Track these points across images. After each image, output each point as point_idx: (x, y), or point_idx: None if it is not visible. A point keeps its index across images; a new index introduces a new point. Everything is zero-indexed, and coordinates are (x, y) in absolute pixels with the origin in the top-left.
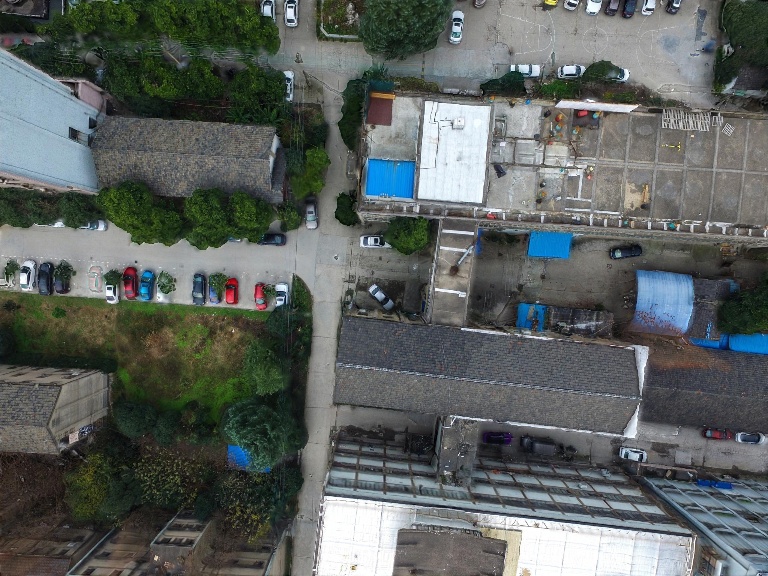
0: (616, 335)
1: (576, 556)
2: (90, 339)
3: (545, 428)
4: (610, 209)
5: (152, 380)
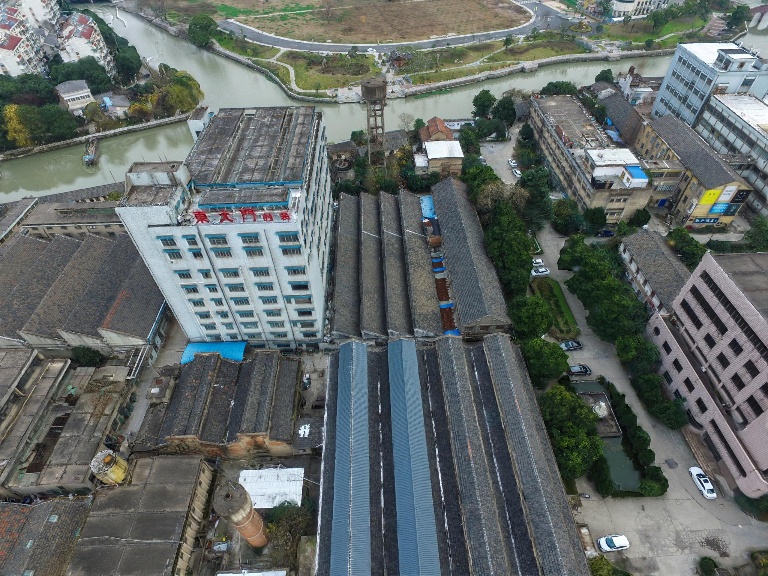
0: (630, 147)
1: None
2: None
3: None
4: (597, 132)
5: None
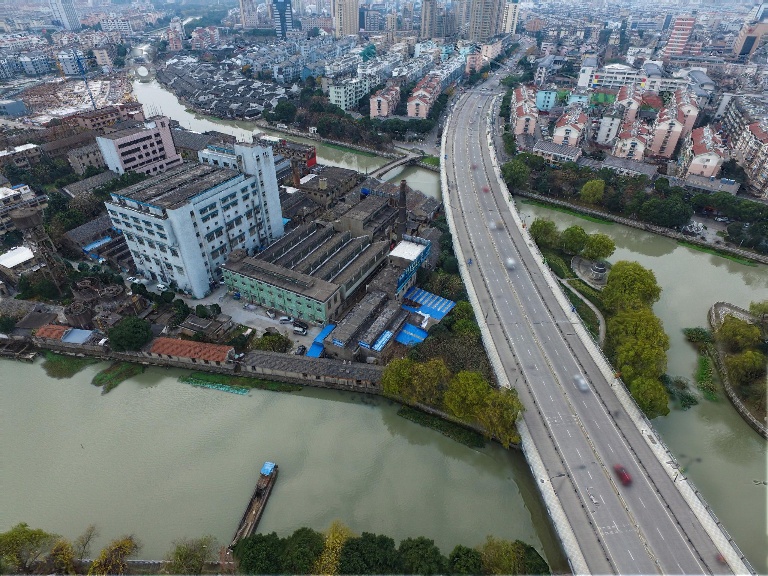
0: None
1: None
2: None
3: None
4: None
5: None
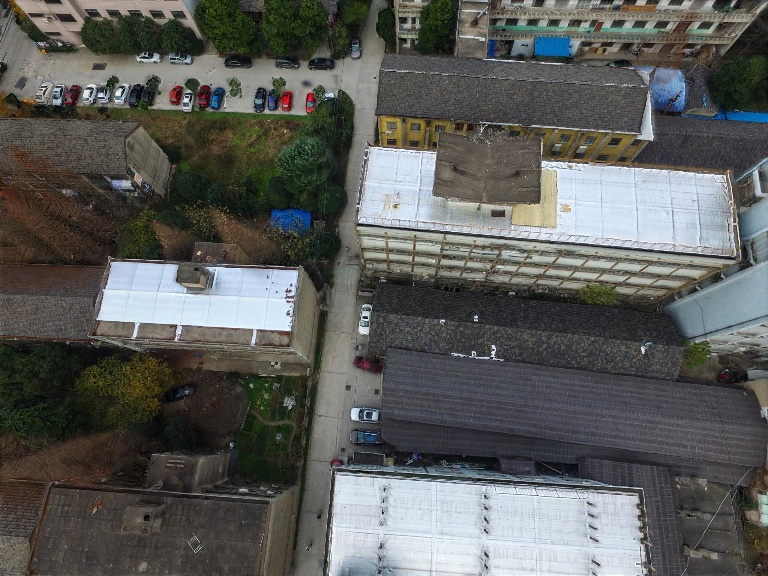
0: None
1: (614, 193)
2: (162, 138)
3: (567, 129)
4: None
5: (209, 170)
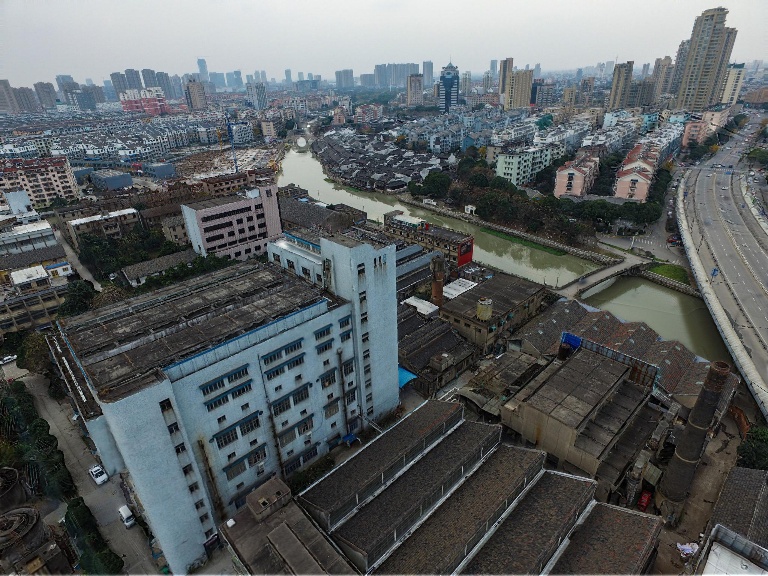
0: None
1: None
2: None
3: None
4: None
5: None
